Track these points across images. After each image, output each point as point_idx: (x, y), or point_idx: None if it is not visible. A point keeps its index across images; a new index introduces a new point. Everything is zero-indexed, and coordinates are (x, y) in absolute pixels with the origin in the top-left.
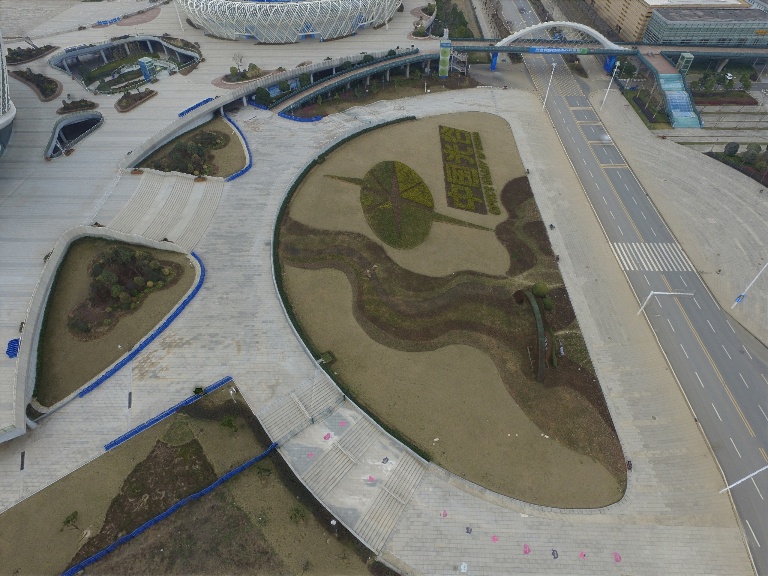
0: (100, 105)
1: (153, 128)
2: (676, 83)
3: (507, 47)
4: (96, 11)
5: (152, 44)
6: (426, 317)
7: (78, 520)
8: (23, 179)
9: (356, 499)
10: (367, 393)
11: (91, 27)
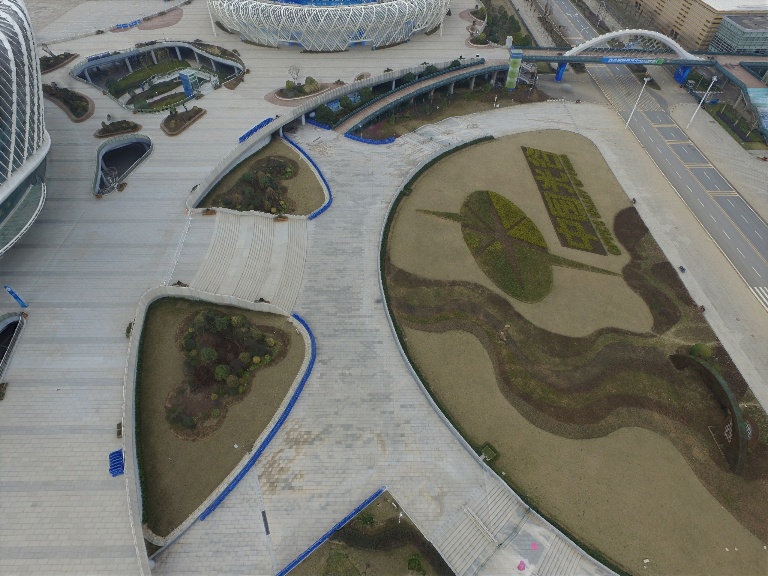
0: (143, 126)
1: (213, 155)
2: (765, 98)
3: (578, 57)
4: (106, 11)
5: (181, 51)
6: (584, 391)
7: None
8: (74, 222)
9: None
10: (548, 499)
11: (109, 31)
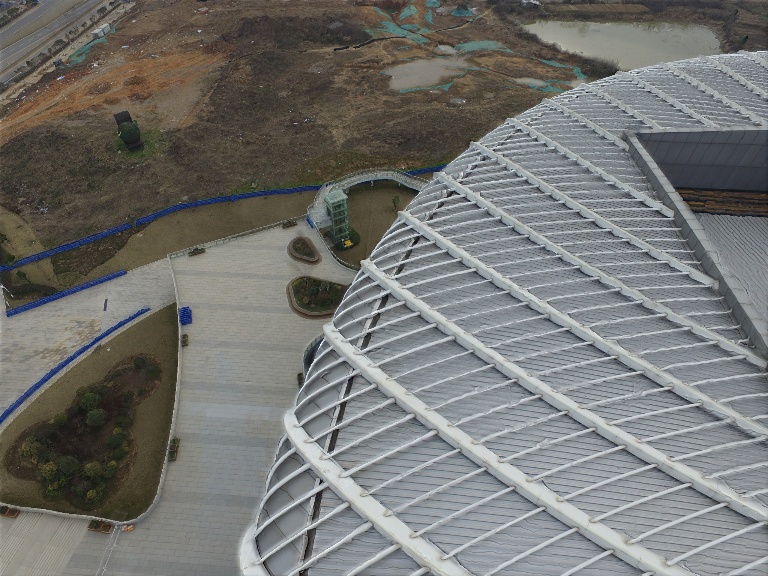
0: None
1: None
2: None
3: None
4: None
5: None
6: None
7: (133, 227)
8: None
9: None
10: None
11: None
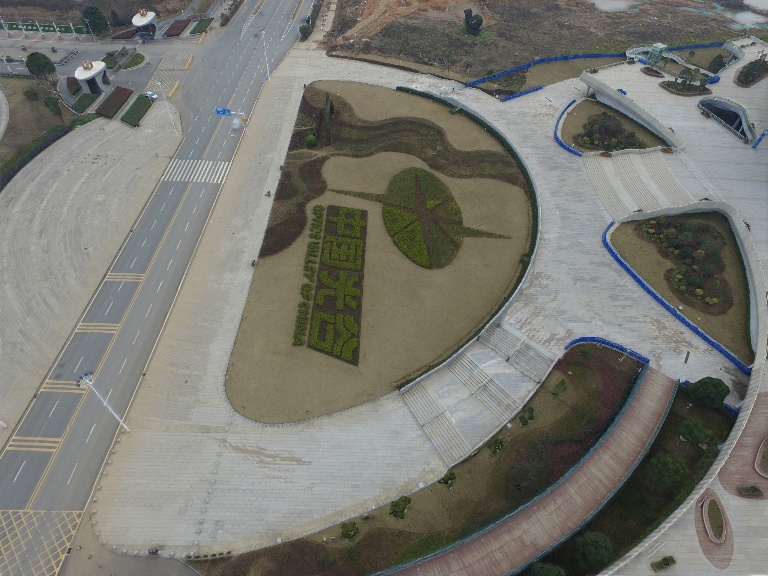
0: None
1: None
2: None
3: None
4: None
5: None
6: None
7: None
8: None
9: (428, 80)
10: None
11: None
